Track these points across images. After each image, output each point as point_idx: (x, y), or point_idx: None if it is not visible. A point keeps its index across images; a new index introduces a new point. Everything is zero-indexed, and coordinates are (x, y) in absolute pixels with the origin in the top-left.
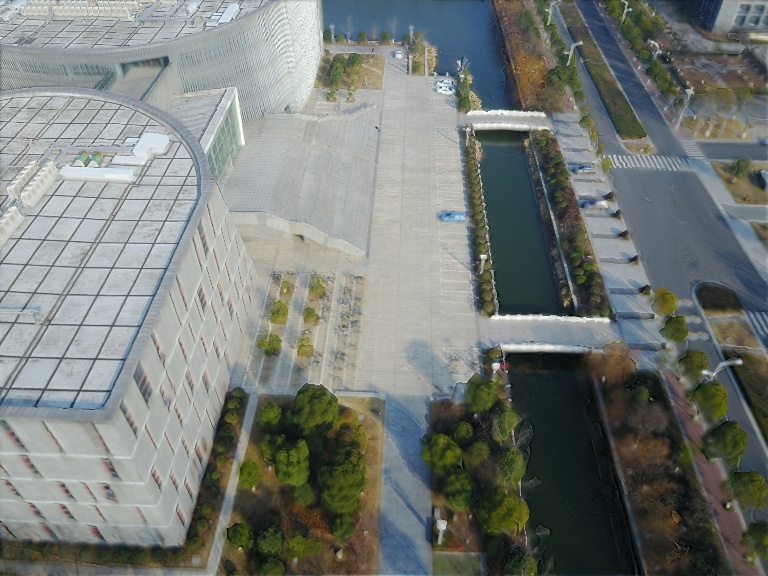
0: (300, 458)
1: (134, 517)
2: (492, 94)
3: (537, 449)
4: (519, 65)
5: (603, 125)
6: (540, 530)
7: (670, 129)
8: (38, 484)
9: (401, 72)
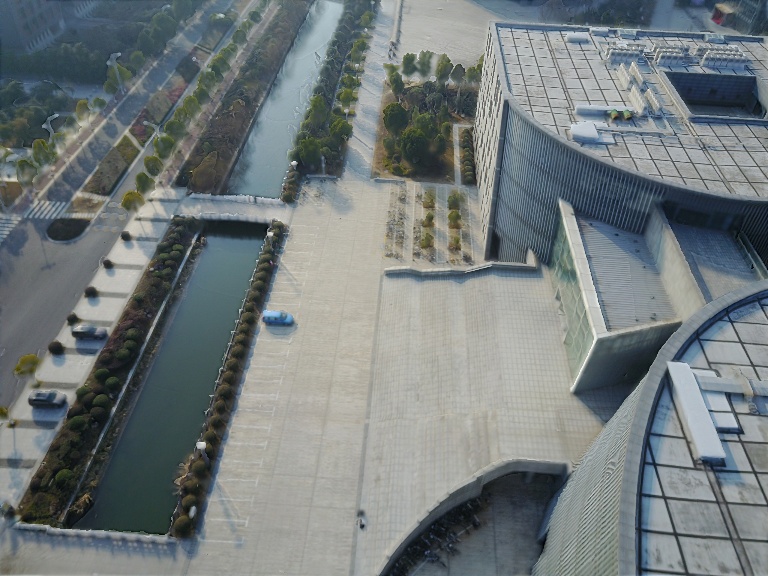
0: None
1: None
2: None
3: None
4: None
5: None
6: None
7: None
8: None
9: None
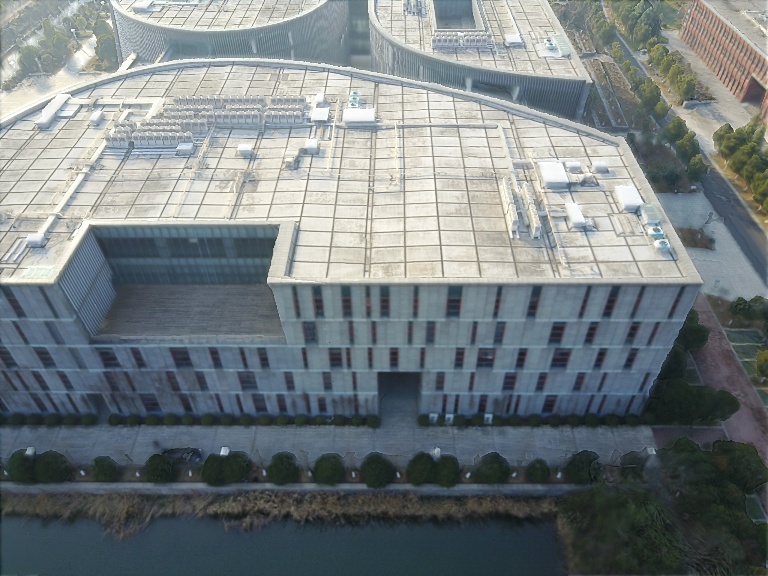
0: None
1: None
2: None
3: None
4: None
5: None
6: None
7: None
8: None
9: None
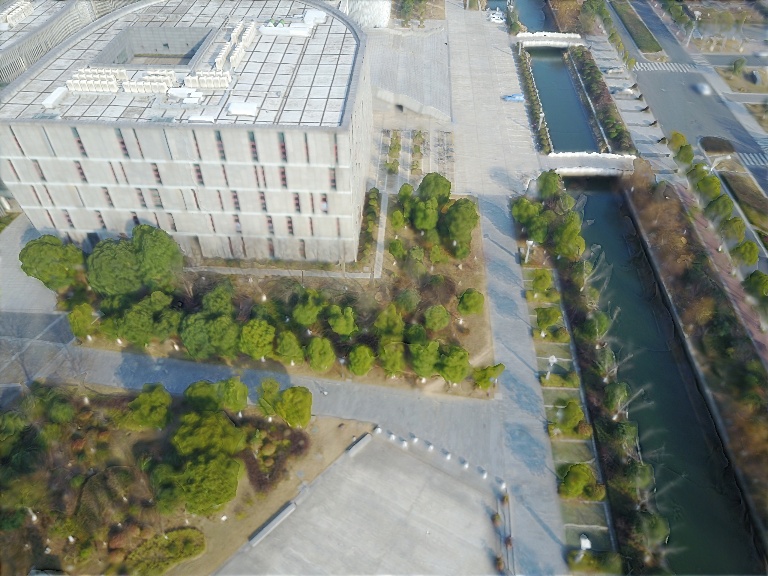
0: (433, 207)
1: (333, 230)
2: (533, 27)
3: (585, 235)
4: (556, 4)
5: (627, 43)
6: (594, 246)
7: (681, 47)
8: (282, 196)
9: (459, 8)
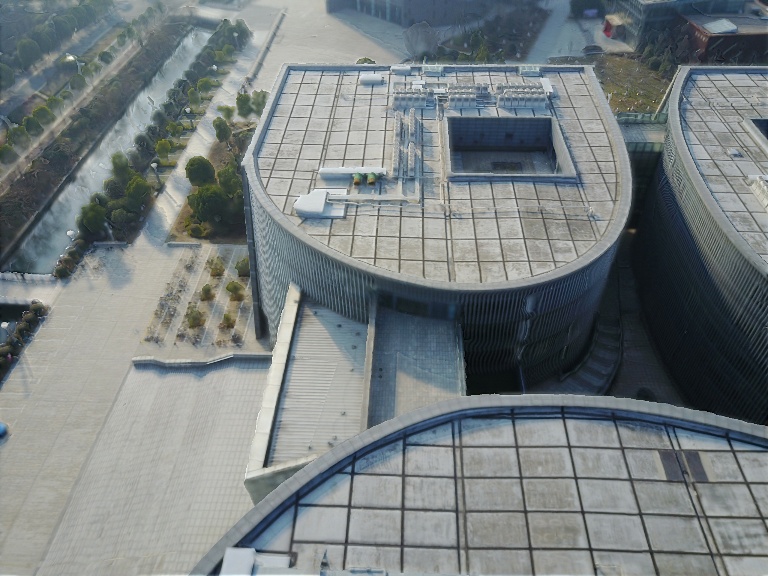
0: None
1: None
2: None
3: None
4: None
5: None
6: None
7: None
8: None
9: None
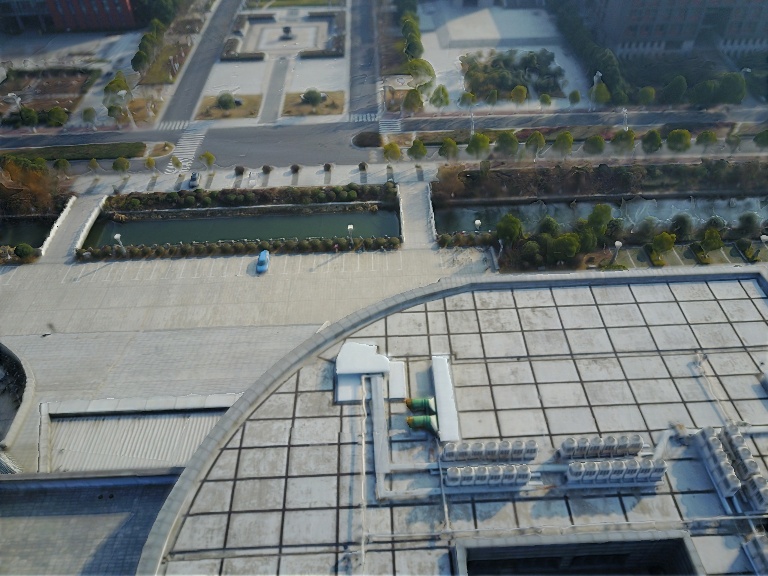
0: None
1: None
2: None
3: None
4: None
5: (111, 164)
6: None
7: (131, 132)
8: None
9: None
